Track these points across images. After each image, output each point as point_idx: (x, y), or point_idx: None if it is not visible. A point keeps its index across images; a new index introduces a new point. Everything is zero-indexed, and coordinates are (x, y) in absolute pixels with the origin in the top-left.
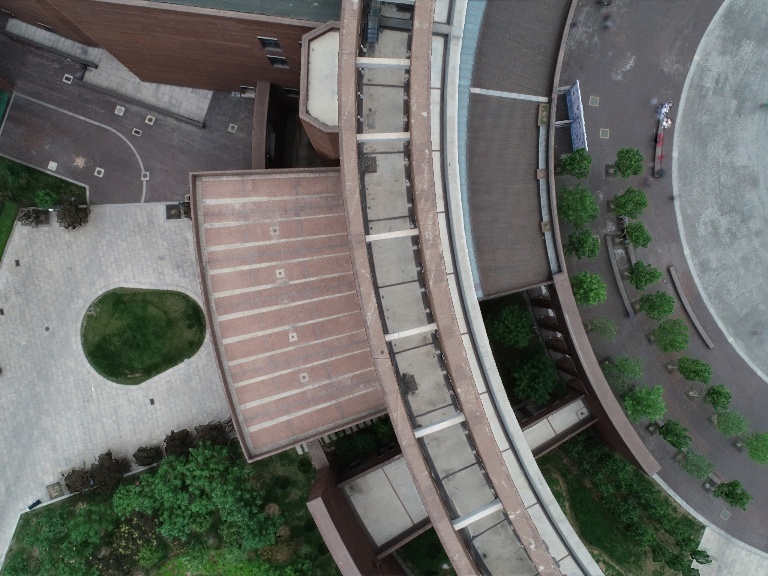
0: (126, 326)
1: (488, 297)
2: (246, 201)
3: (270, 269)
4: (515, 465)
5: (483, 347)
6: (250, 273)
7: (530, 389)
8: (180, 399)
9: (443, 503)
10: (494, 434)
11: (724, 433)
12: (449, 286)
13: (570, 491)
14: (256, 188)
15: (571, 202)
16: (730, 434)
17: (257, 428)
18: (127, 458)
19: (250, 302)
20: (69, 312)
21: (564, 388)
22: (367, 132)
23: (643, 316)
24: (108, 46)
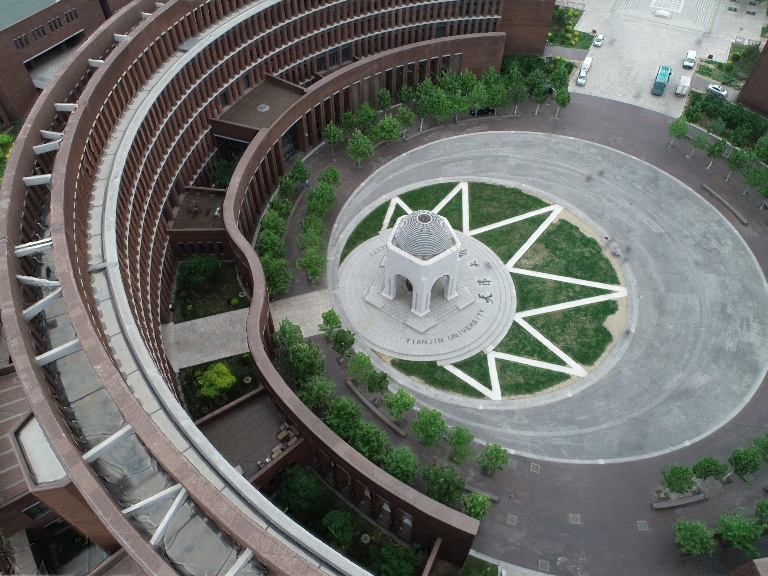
0: None
1: None
2: None
3: None
4: None
5: None
6: None
7: None
8: None
9: None
10: None
11: None
12: None
13: None
14: None
15: None
16: None
17: None
18: None
19: None
20: None
21: None
22: None
23: (755, 204)
24: None
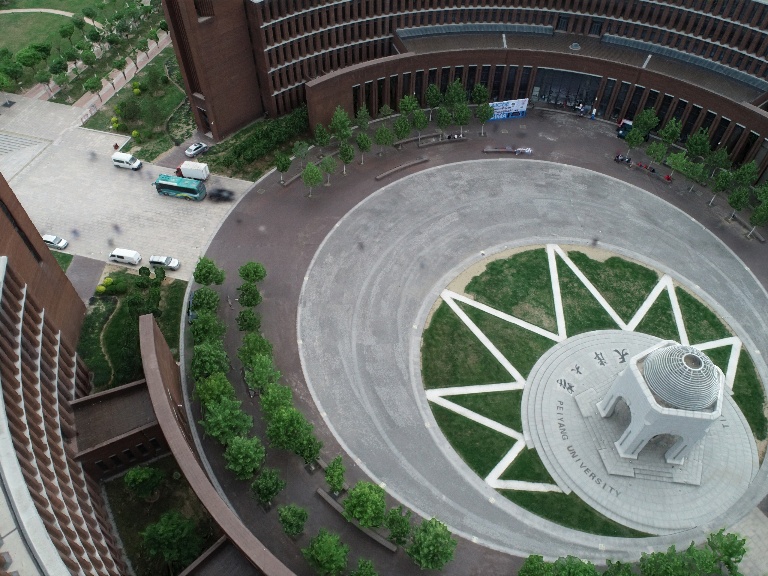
0: None
1: None
2: None
3: None
4: None
5: None
6: None
7: None
8: None
9: None
10: None
11: None
12: None
13: None
14: None
15: None
16: None
17: None
18: None
19: None
20: None
21: None
22: None
23: (394, 151)
24: None
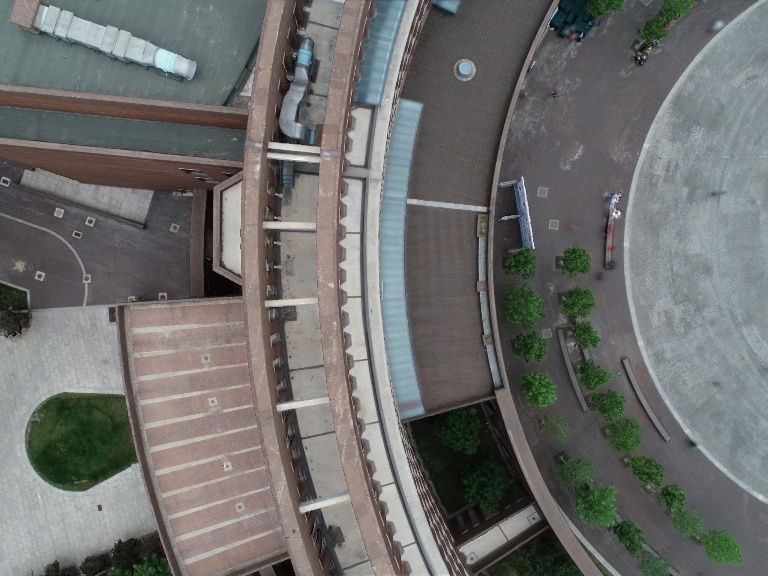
0: (71, 432)
1: (429, 414)
2: (176, 329)
3: (202, 398)
4: None
5: (410, 497)
6: (182, 402)
7: (480, 496)
8: (128, 504)
9: None
10: None
11: (680, 532)
12: (374, 435)
13: None
14: (186, 315)
15: (517, 305)
16: (686, 533)
17: (193, 560)
18: (76, 566)
19: (183, 432)
20: (13, 419)
21: (515, 492)
22: (286, 279)
23: None
24: (35, 165)
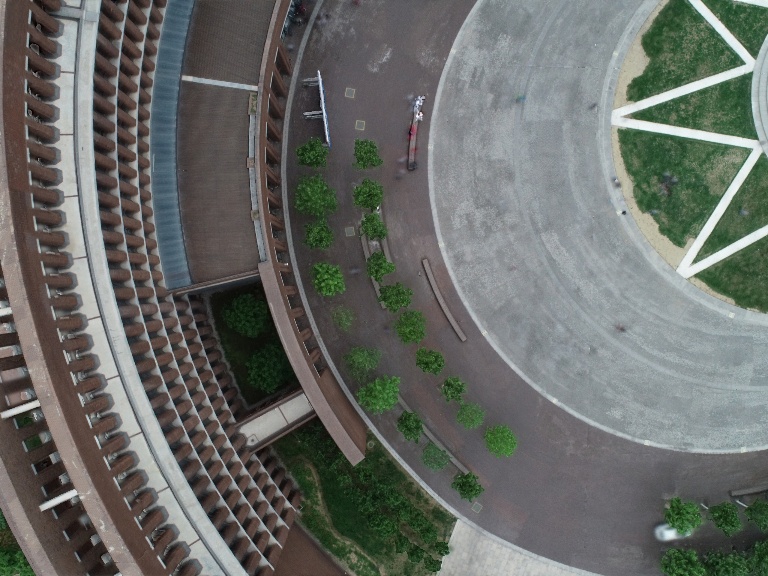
0: None
1: (194, 285)
2: None
3: None
4: (146, 449)
5: (115, 331)
6: None
7: (260, 378)
8: None
9: (39, 484)
10: (126, 418)
11: (464, 425)
12: (81, 270)
13: (322, 481)
14: None
15: (302, 192)
16: (468, 426)
17: None
18: None
19: None
20: None
21: None
22: None
23: None
24: None
